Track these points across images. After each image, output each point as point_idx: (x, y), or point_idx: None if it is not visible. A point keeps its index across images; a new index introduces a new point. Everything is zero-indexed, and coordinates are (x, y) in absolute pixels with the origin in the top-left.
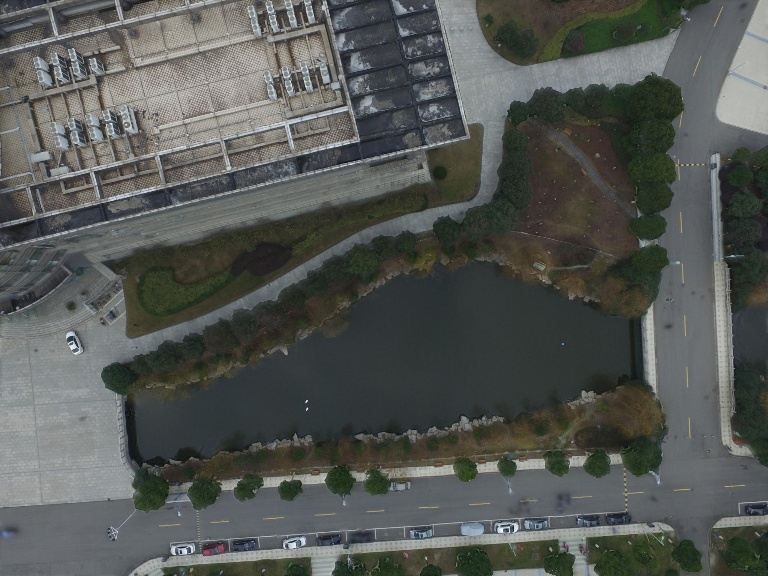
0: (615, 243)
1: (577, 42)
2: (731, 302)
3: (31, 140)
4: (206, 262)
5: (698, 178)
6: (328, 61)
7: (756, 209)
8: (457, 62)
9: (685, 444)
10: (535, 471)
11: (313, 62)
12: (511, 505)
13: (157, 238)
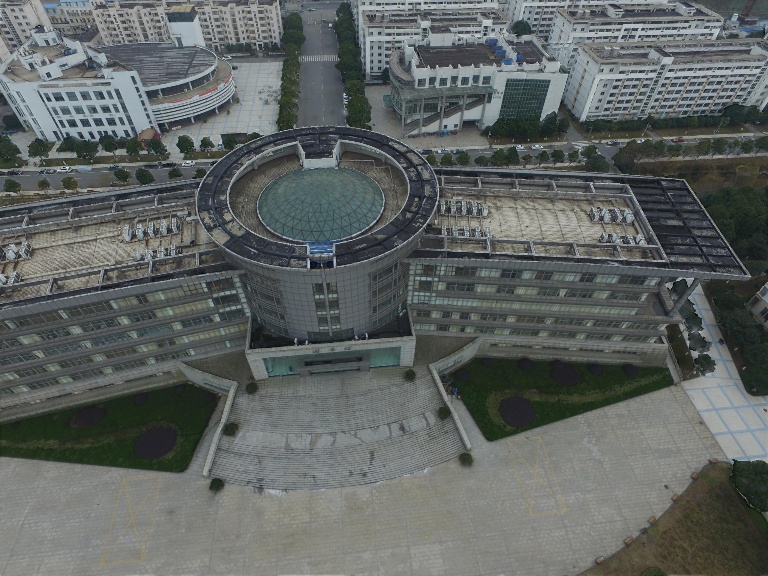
0: None
1: None
2: None
3: None
4: None
5: None
6: None
7: None
8: None
9: None
10: None
11: None
12: (57, 179)
13: None
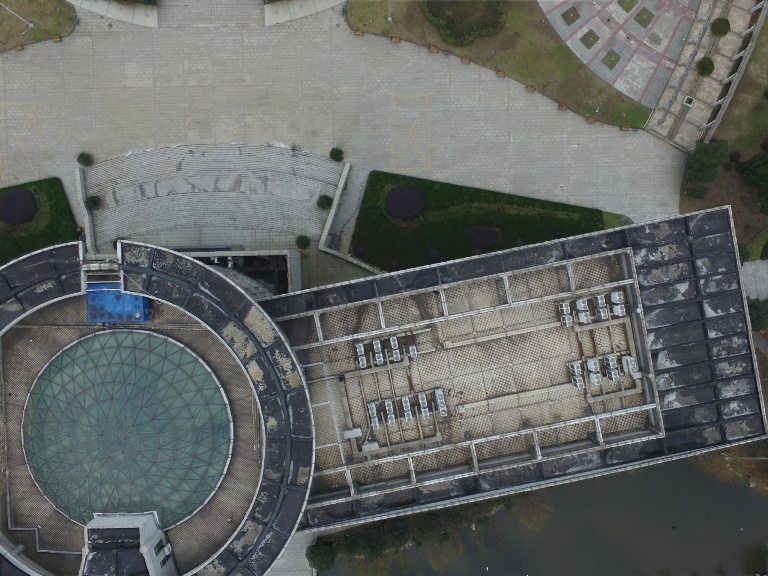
0: None
1: None
2: None
3: (341, 413)
4: None
5: None
6: (630, 351)
7: None
8: None
9: None
10: None
11: (615, 350)
12: None
13: None
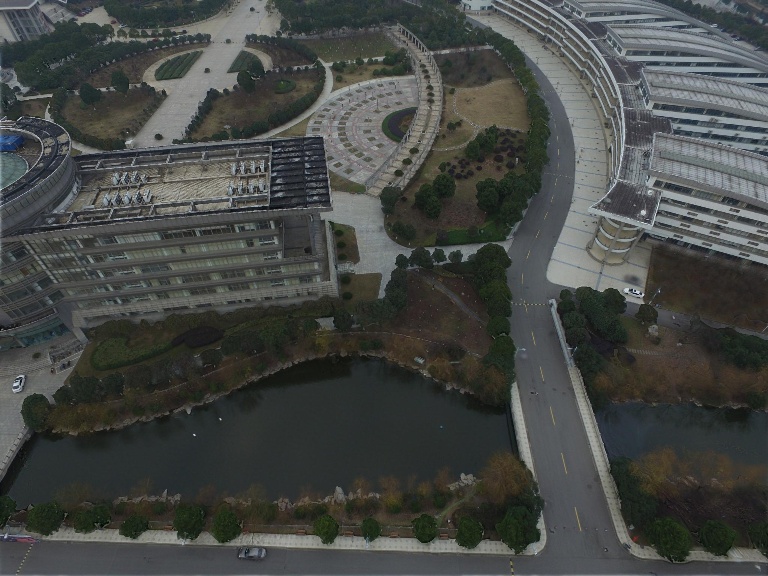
0: (481, 348)
1: (442, 234)
2: (588, 395)
3: None
4: (156, 336)
5: (542, 312)
6: None
7: (581, 321)
8: (369, 244)
9: (576, 537)
10: (408, 555)
11: None
12: None
13: (129, 307)
